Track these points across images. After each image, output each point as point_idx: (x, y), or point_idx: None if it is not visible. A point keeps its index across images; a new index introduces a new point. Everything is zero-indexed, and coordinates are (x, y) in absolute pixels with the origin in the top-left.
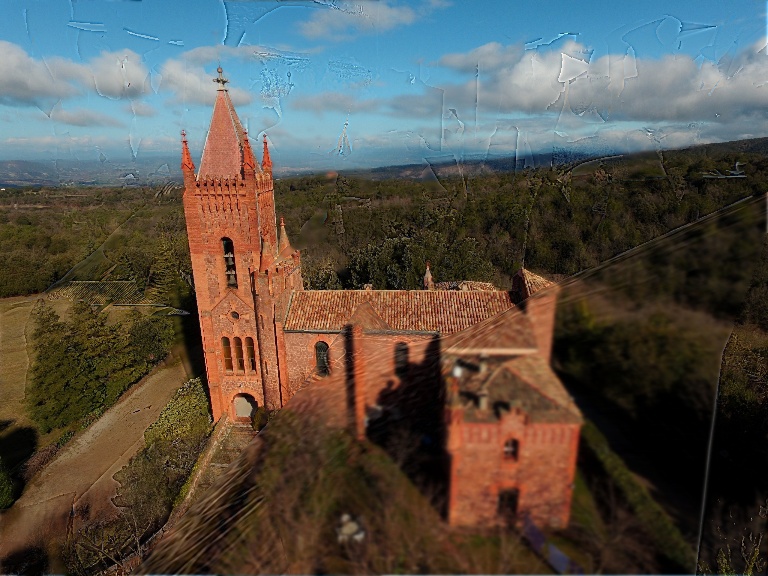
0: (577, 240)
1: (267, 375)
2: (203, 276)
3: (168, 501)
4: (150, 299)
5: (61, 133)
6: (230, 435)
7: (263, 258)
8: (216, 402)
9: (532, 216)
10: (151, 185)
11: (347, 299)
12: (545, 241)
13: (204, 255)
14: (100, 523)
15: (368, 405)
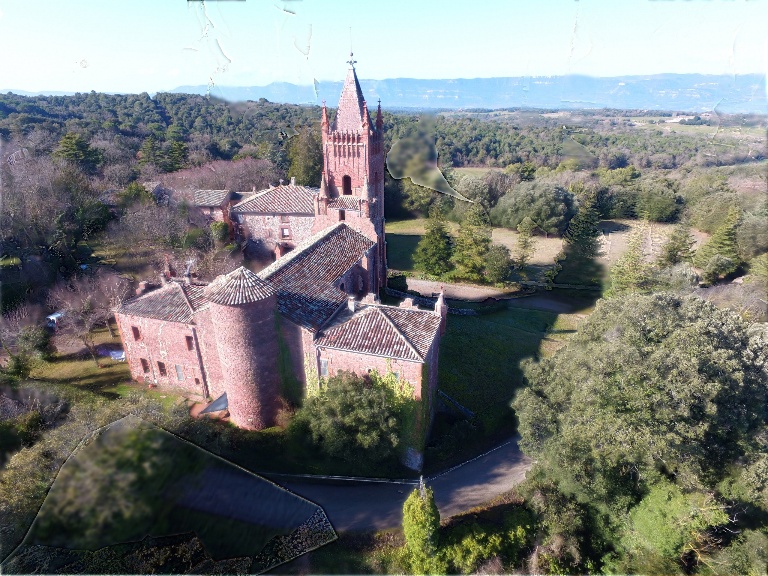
0: None
1: None
2: None
3: None
4: None
5: None
6: None
7: None
8: None
9: None
10: None
11: None
12: None
13: None
14: None
15: None
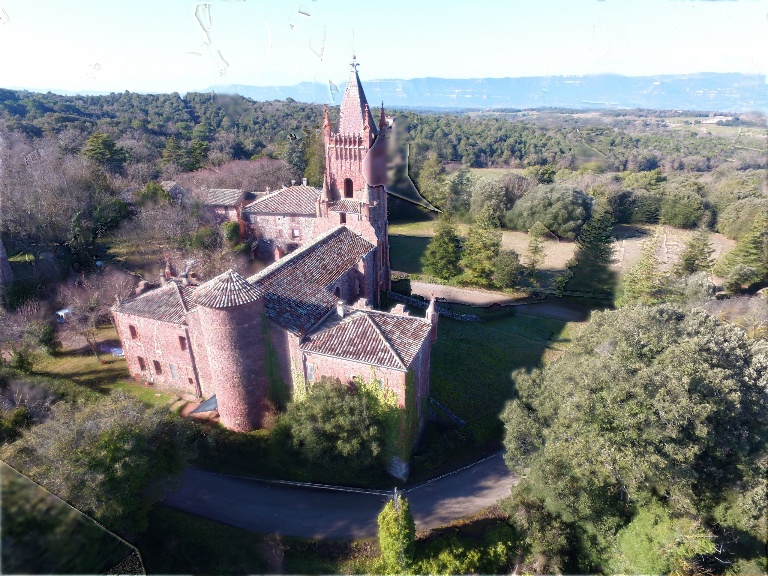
0: None
1: None
2: None
3: None
4: None
5: (761, 75)
6: None
7: None
8: None
9: None
10: None
11: None
12: None
13: None
14: None
15: None
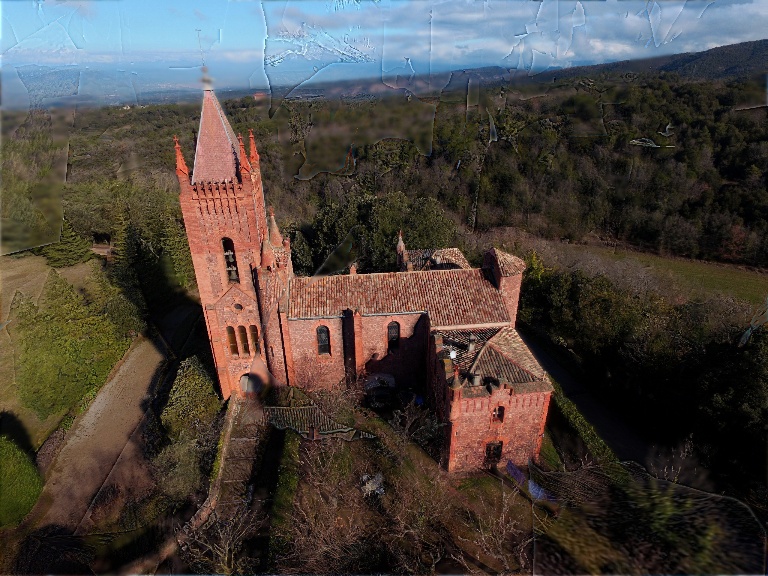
0: (525, 191)
1: (273, 357)
2: (205, 274)
3: (204, 477)
4: (114, 271)
5: None
6: (241, 410)
7: (264, 255)
8: (225, 383)
9: (484, 167)
10: (96, 149)
11: (341, 284)
12: (496, 191)
13: (205, 255)
14: (136, 500)
15: (604, 574)
